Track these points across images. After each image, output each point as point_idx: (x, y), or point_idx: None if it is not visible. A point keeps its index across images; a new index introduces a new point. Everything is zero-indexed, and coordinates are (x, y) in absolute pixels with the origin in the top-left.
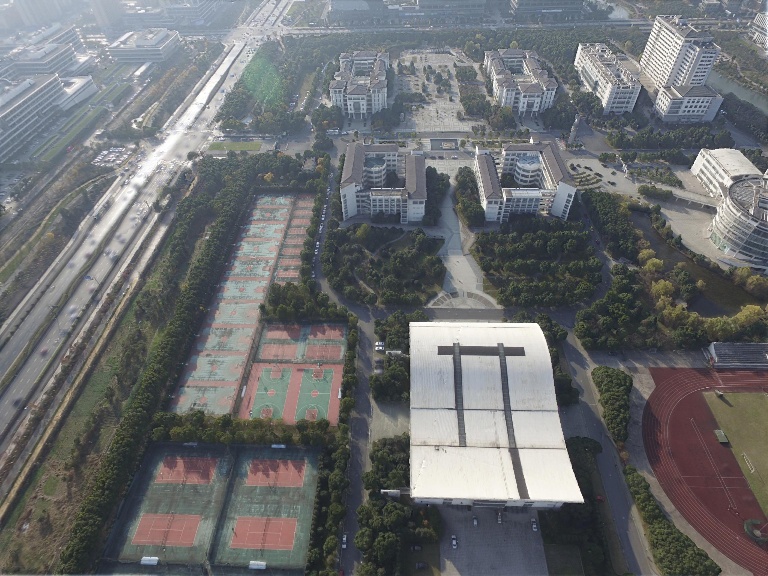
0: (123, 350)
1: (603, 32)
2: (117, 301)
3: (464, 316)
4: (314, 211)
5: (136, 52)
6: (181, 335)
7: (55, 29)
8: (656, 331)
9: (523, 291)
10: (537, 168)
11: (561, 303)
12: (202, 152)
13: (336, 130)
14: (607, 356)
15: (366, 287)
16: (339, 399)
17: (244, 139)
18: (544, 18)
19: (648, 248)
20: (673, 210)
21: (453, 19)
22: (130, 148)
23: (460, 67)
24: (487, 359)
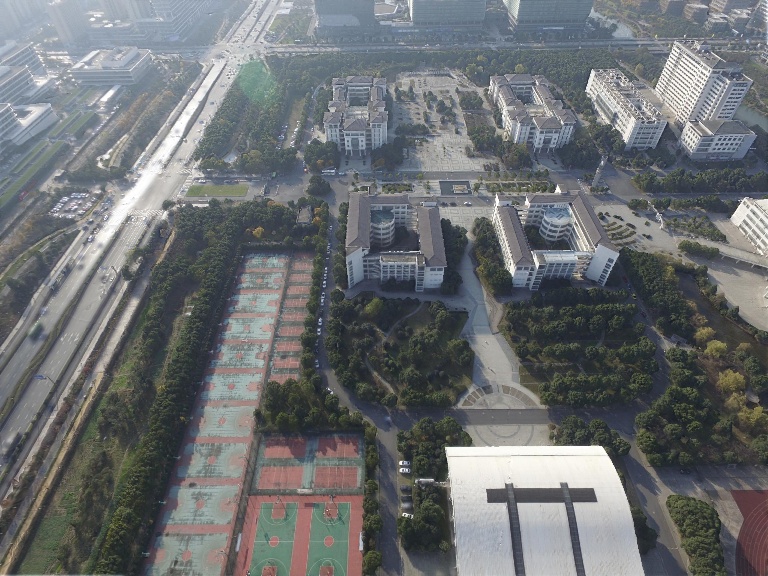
0: (83, 484)
1: (610, 53)
2: (76, 407)
3: (502, 420)
4: (314, 278)
5: (102, 74)
6: (157, 461)
7: (9, 48)
8: (731, 438)
9: (571, 388)
10: (567, 223)
11: (614, 400)
12: (179, 201)
13: (332, 170)
14: (679, 475)
15: (382, 381)
16: (361, 551)
17: (228, 181)
18: (546, 36)
19: (705, 325)
20: (720, 271)
21: (449, 36)
22: (95, 194)
23: (463, 93)
24: (550, 508)
